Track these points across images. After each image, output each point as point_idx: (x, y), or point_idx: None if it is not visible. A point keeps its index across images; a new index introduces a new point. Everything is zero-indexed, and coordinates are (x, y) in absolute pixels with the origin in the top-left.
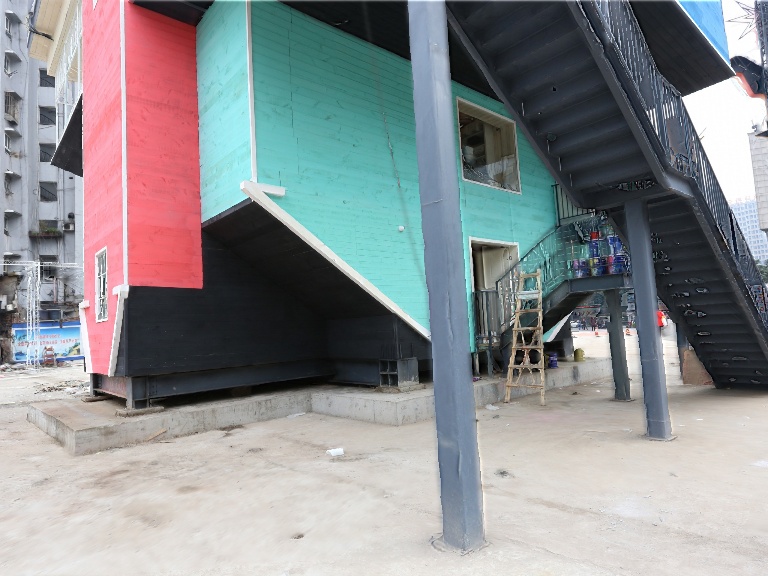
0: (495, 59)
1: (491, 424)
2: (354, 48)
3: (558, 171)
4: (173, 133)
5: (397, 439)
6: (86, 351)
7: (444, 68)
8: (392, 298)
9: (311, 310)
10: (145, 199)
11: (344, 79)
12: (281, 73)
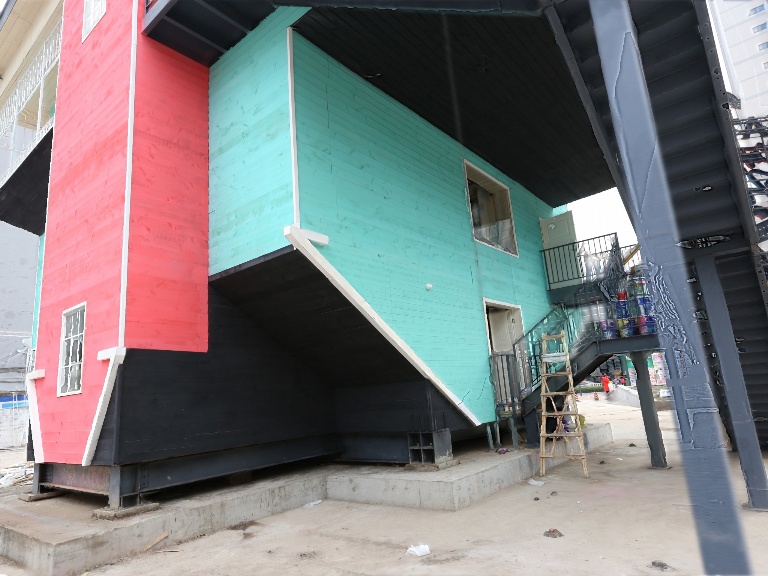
0: (600, 106)
1: (558, 502)
2: (381, 102)
3: (641, 224)
4: (182, 175)
5: (472, 528)
6: (36, 434)
7: None
8: (425, 362)
9: (319, 377)
10: (148, 246)
11: (374, 130)
12: (320, 117)
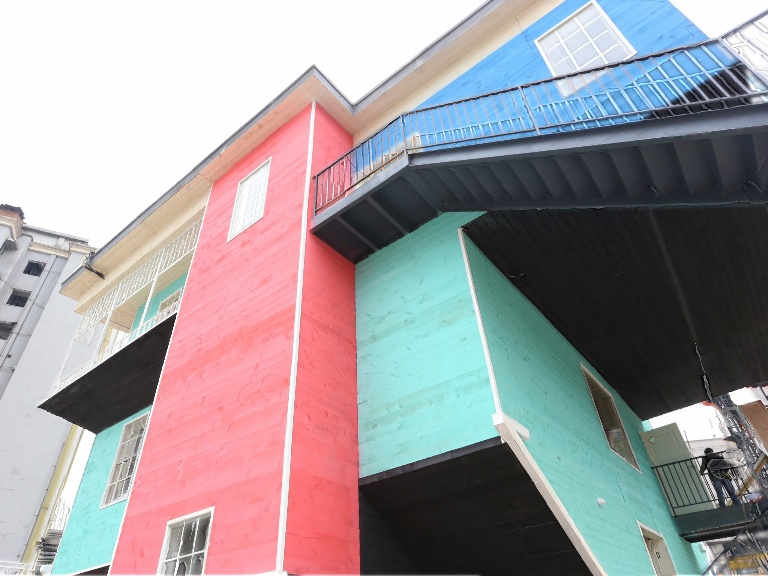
0: None
1: None
2: (521, 300)
3: None
4: (336, 361)
5: None
6: None
7: None
8: None
9: None
10: (308, 437)
11: (524, 325)
12: (492, 306)
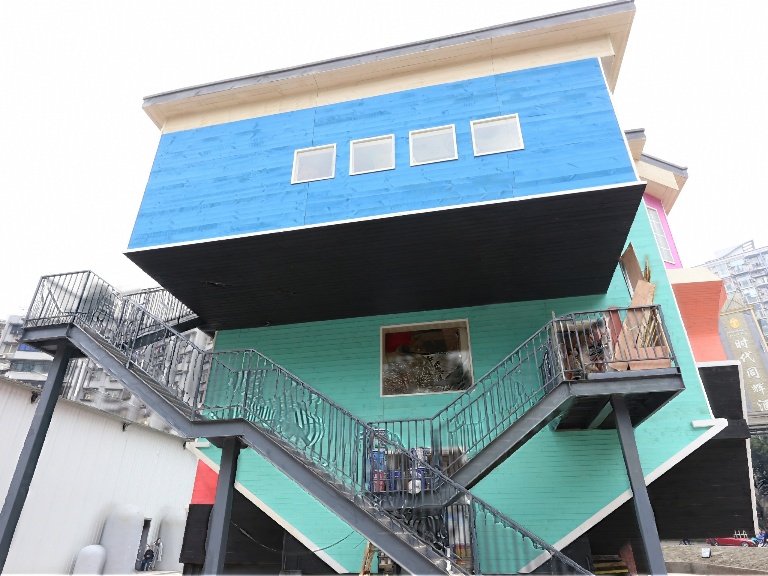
0: None
1: None
2: (282, 333)
3: None
4: None
5: None
6: None
7: (37, 422)
8: (283, 514)
9: None
10: None
11: (270, 357)
12: (226, 371)
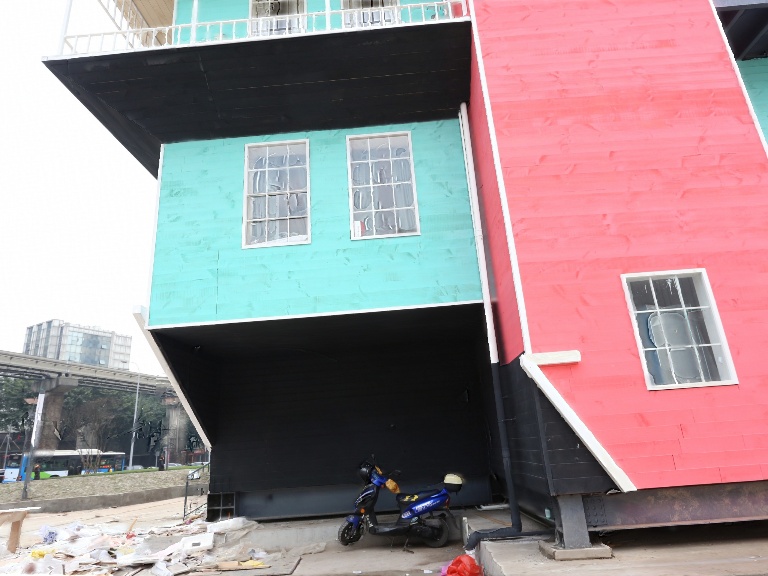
0: None
1: None
2: None
3: None
4: None
5: None
6: None
7: None
8: None
9: None
10: None
11: None
12: None
